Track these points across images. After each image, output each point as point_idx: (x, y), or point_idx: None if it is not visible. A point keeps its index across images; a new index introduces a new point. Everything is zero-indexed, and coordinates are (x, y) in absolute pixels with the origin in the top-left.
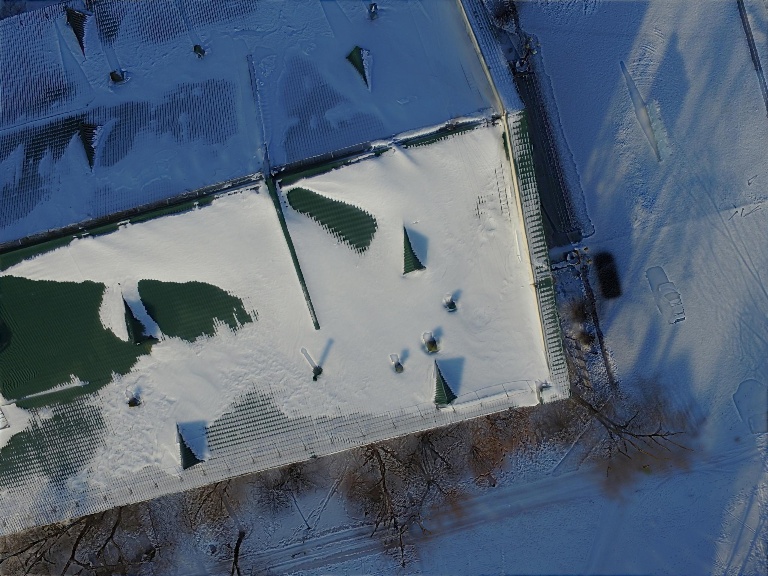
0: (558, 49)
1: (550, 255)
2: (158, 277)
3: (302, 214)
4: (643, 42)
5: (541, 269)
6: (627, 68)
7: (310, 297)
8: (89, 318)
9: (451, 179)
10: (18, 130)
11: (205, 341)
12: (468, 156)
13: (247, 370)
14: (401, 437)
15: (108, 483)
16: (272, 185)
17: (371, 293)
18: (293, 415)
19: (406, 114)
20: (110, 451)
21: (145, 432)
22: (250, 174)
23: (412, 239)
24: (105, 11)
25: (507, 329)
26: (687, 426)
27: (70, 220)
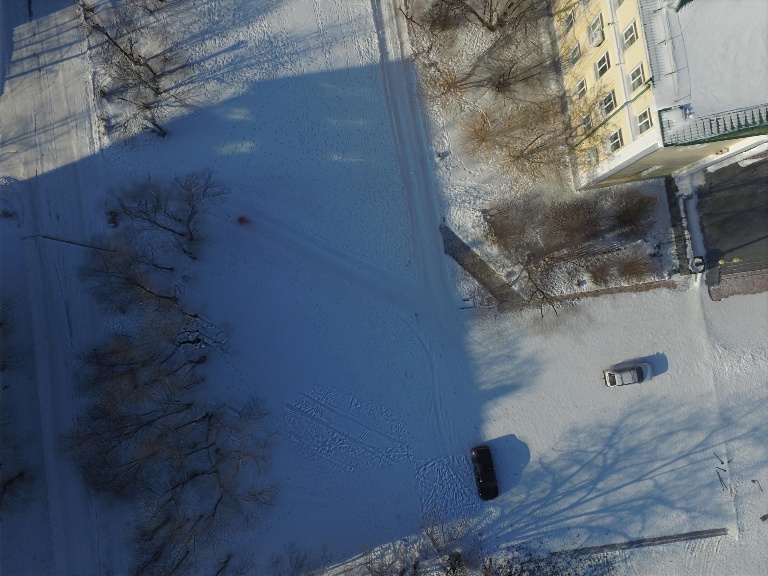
0: None
1: (698, 243)
2: None
3: None
4: None
5: None
6: None
7: None
8: None
9: None
10: None
11: None
12: None
13: None
14: (501, 61)
15: None
16: None
17: None
18: None
19: None
20: None
21: None
22: None
23: None
24: None
25: (765, 70)
26: (484, 379)
27: None
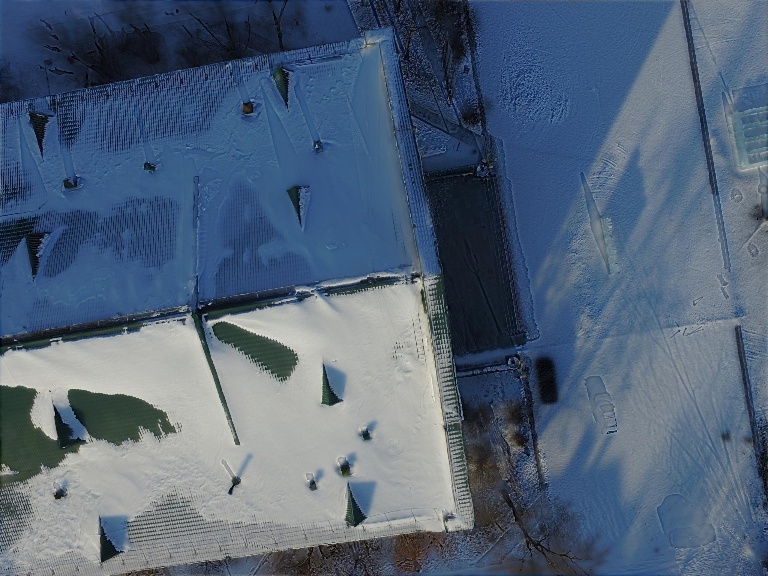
0: (521, 155)
1: (493, 356)
2: (87, 388)
3: (226, 344)
4: (605, 156)
5: (451, 414)
6: (587, 180)
7: (231, 417)
8: (21, 418)
9: (370, 326)
10: None
11: (130, 446)
12: (387, 307)
13: (169, 474)
14: None
15: (32, 563)
16: (197, 320)
17: (290, 417)
18: (211, 518)
19: (332, 261)
20: (36, 535)
21: (70, 521)
22: (178, 306)
23: (330, 376)
24: (67, 113)
25: (419, 460)
26: (610, 533)
27: (7, 330)
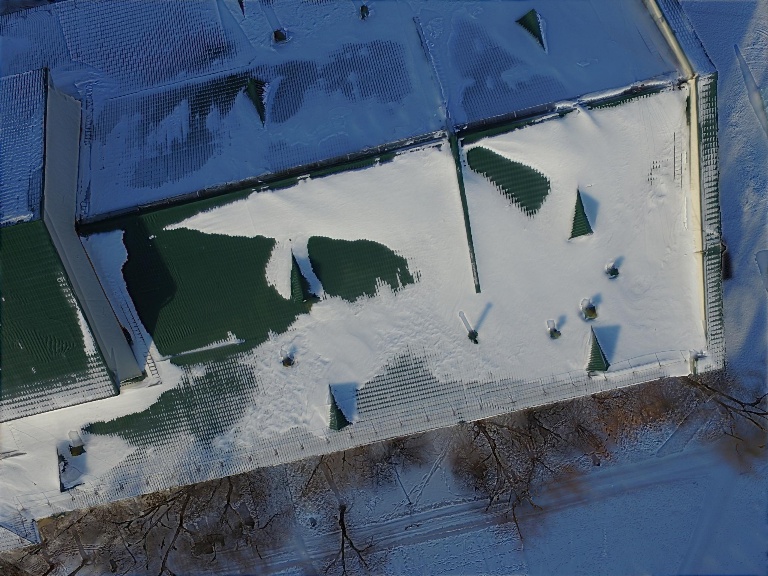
0: None
1: None
2: (329, 234)
3: (479, 174)
4: (757, 26)
5: (711, 236)
6: (741, 52)
7: (476, 259)
8: (255, 274)
9: (630, 143)
10: (179, 86)
11: (365, 301)
12: (650, 120)
13: (403, 332)
14: (505, 414)
15: (254, 443)
16: (456, 143)
17: (535, 257)
18: (444, 379)
19: (588, 76)
20: (259, 411)
21: (296, 392)
22: (433, 131)
23: (585, 202)
24: None
25: (665, 298)
26: None
27: (247, 174)
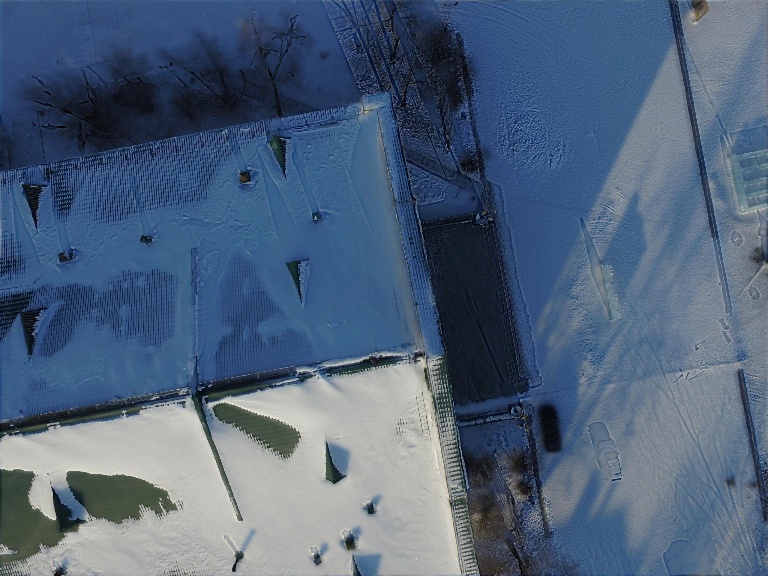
0: (520, 201)
1: (495, 405)
2: (86, 470)
3: (227, 424)
4: (604, 201)
5: (456, 489)
6: (586, 225)
7: (233, 494)
8: (18, 499)
9: (373, 403)
10: None
11: (131, 523)
12: (390, 386)
13: (171, 550)
14: None
15: None
16: (197, 403)
17: (293, 492)
18: None
19: (334, 339)
20: None
21: None
22: (178, 388)
23: (333, 453)
24: (61, 182)
25: (424, 532)
26: None
27: (3, 414)
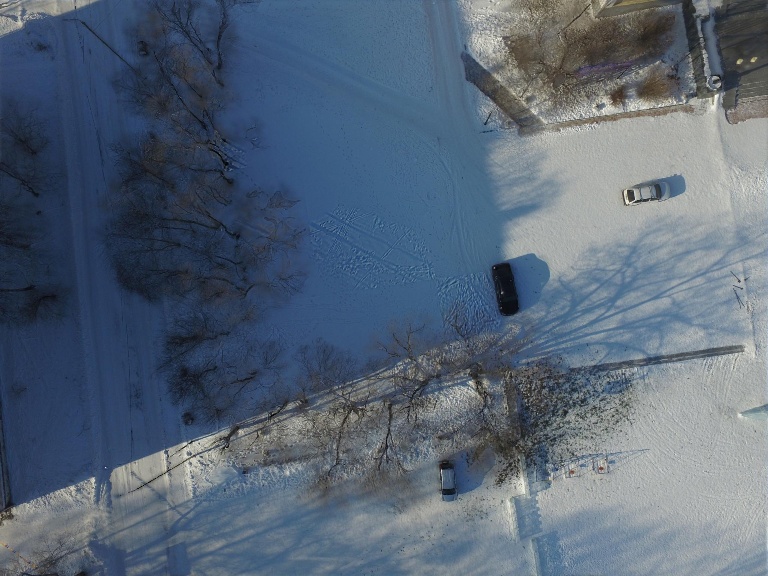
0: None
1: (716, 64)
2: None
3: None
4: None
5: None
6: None
7: None
8: None
9: None
10: None
11: None
12: None
13: None
14: None
15: None
16: None
17: None
18: None
19: None
20: None
21: None
22: None
23: None
24: None
25: None
26: (505, 200)
27: None
